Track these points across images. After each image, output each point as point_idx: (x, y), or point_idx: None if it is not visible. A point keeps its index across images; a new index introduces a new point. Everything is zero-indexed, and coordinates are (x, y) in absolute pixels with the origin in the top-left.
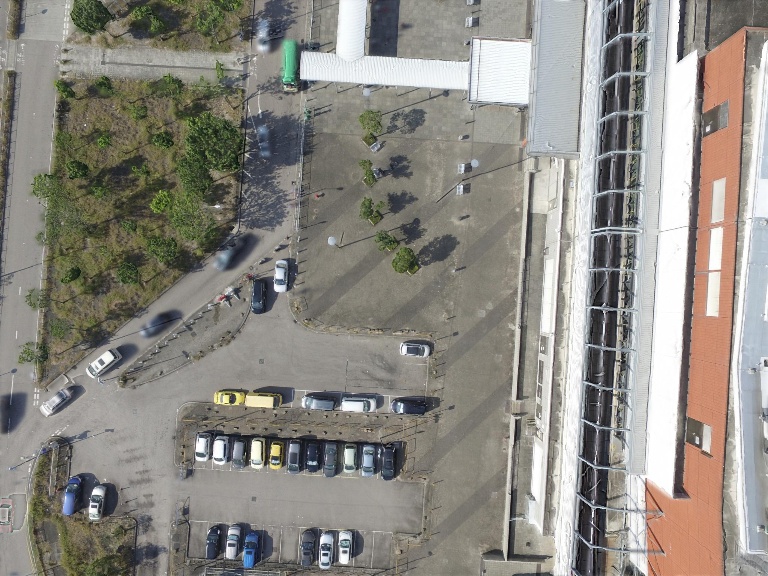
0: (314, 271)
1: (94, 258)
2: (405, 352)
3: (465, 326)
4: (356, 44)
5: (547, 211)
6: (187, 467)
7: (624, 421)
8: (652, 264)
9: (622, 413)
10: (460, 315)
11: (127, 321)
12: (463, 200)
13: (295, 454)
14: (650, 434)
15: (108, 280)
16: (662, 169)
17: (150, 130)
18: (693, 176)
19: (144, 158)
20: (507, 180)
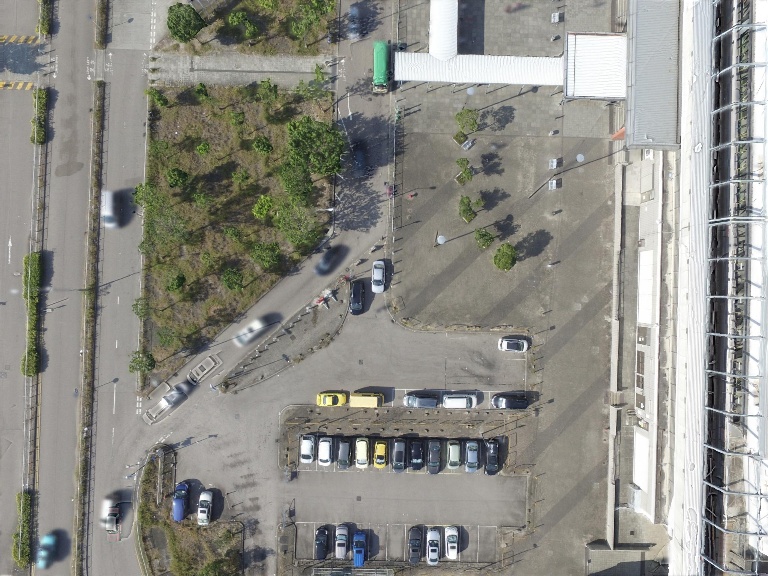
0: (410, 270)
1: (191, 265)
2: (505, 348)
3: (561, 320)
4: (449, 43)
5: (640, 203)
6: (291, 469)
7: (744, 408)
8: None
9: (741, 400)
10: (556, 309)
11: (226, 327)
12: (555, 195)
13: (401, 452)
14: None
15: (206, 287)
16: None
17: (242, 136)
18: None
19: (237, 164)
20: (598, 174)
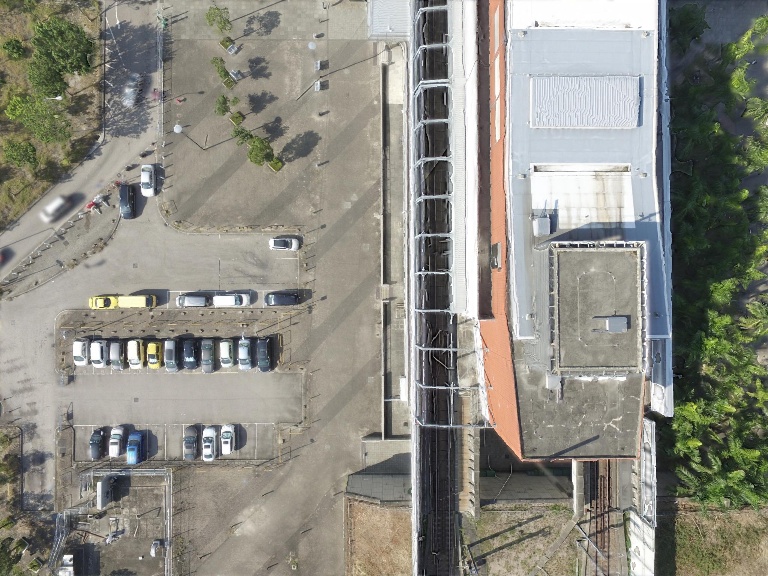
0: (181, 174)
1: None
2: (272, 245)
3: (332, 218)
4: None
5: (403, 101)
6: (68, 373)
7: None
8: (460, 110)
9: None
10: (326, 208)
11: None
12: (322, 96)
13: (170, 351)
14: (468, 272)
15: None
16: (463, 18)
17: None
18: (479, 13)
19: (6, 74)
20: (363, 74)
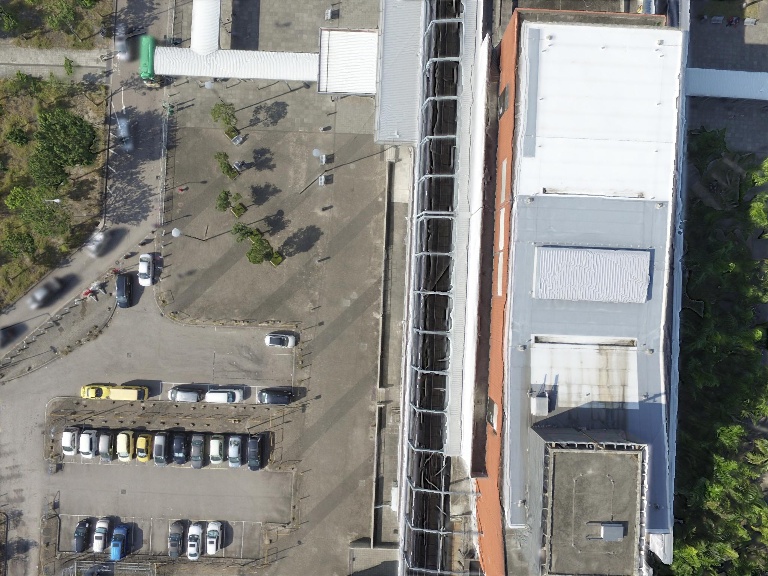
0: (180, 264)
1: None
2: (268, 343)
3: (330, 316)
4: (209, 38)
5: (408, 200)
6: (56, 461)
7: None
8: (463, 247)
9: None
10: (325, 305)
11: None
12: (326, 191)
13: (160, 446)
14: (464, 415)
15: None
16: (470, 152)
17: (15, 128)
18: (486, 158)
19: (9, 156)
20: (369, 170)
